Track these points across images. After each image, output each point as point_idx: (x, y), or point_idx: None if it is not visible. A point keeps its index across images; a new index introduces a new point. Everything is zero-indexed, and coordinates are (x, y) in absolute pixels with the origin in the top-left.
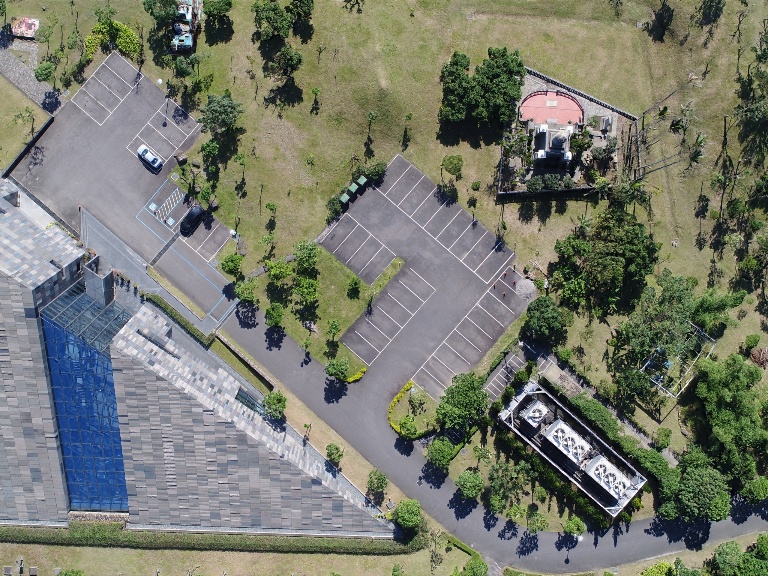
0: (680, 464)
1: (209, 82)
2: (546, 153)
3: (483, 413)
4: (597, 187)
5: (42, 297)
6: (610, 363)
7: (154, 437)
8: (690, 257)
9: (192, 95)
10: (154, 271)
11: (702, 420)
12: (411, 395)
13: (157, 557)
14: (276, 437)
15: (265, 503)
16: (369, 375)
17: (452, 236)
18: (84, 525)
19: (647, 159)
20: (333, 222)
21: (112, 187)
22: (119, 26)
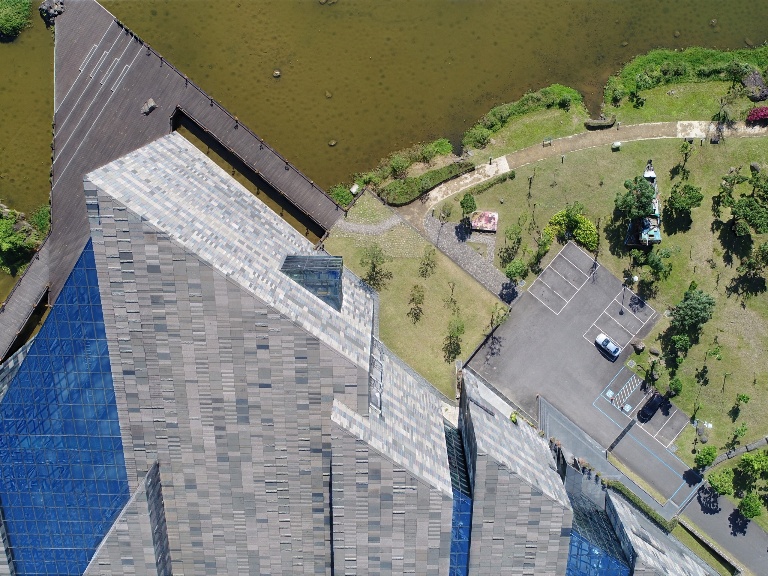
0: None
1: (668, 271)
2: None
3: None
4: None
5: None
6: None
7: None
8: None
9: (649, 284)
10: (613, 457)
11: None
12: None
13: None
14: None
15: None
16: None
17: None
18: None
19: None
20: None
21: (569, 375)
22: (578, 218)
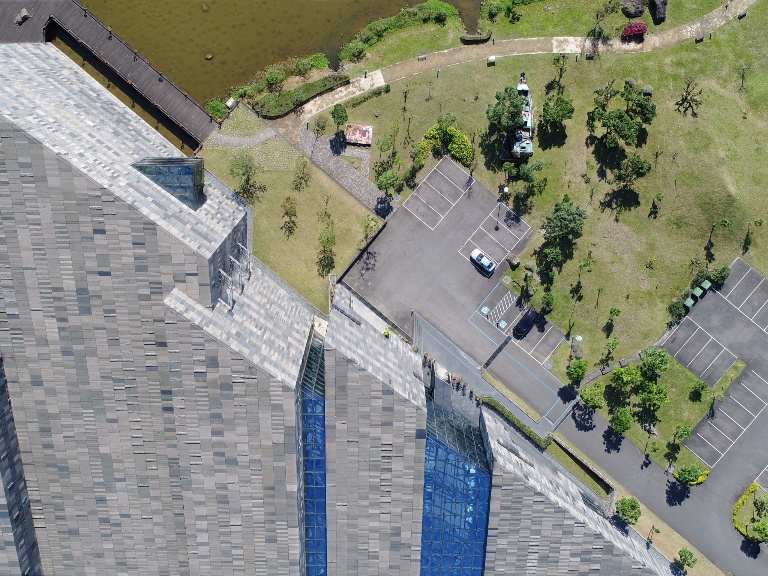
0: None
1: (542, 186)
2: None
3: None
4: None
5: None
6: None
7: (520, 548)
8: None
9: (524, 199)
10: (488, 374)
11: None
12: (756, 497)
13: None
14: (629, 543)
15: None
16: (712, 477)
17: None
18: None
19: None
20: (674, 325)
21: (444, 291)
22: (452, 132)
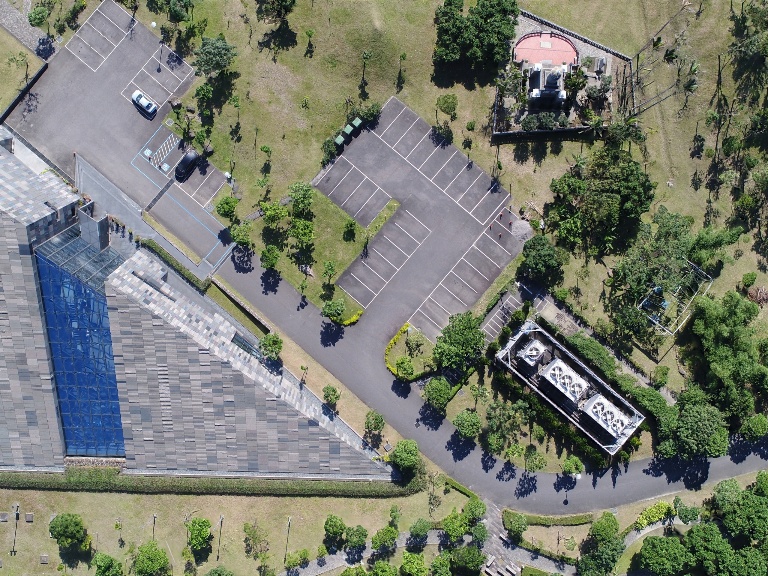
0: (678, 402)
1: (203, 27)
2: (541, 92)
3: (480, 354)
4: (592, 124)
5: (36, 235)
6: (607, 303)
7: (150, 378)
8: (686, 197)
9: (186, 40)
10: (149, 217)
11: (700, 358)
12: (408, 337)
13: (154, 502)
14: (272, 379)
15: (262, 446)
16: (365, 318)
17: (447, 178)
18: (80, 470)
19: (642, 100)
20: (328, 165)
21: (107, 133)
22: None
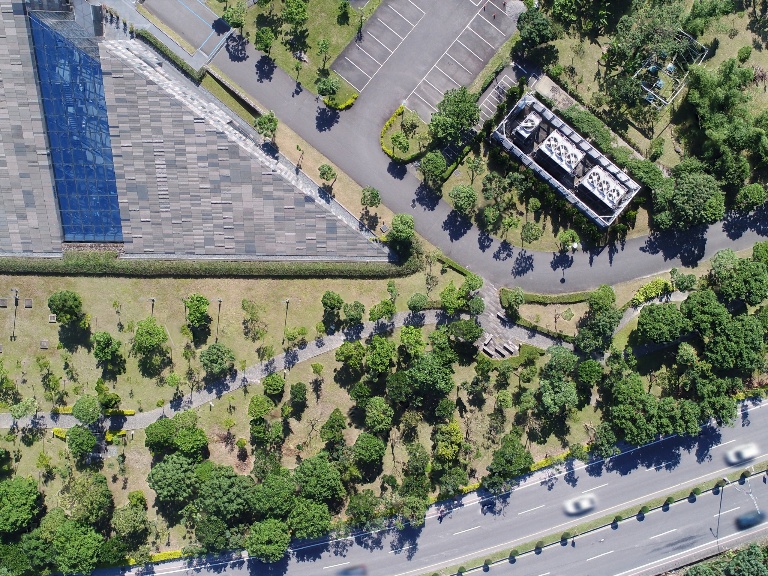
0: (674, 172)
1: None
2: None
3: (475, 134)
4: None
5: None
6: (602, 83)
7: (146, 151)
8: None
9: None
10: (143, 8)
11: (695, 132)
12: (403, 119)
13: (152, 286)
14: (268, 159)
15: (259, 226)
16: (360, 101)
17: None
18: (78, 254)
19: None
20: None
21: None
22: None
